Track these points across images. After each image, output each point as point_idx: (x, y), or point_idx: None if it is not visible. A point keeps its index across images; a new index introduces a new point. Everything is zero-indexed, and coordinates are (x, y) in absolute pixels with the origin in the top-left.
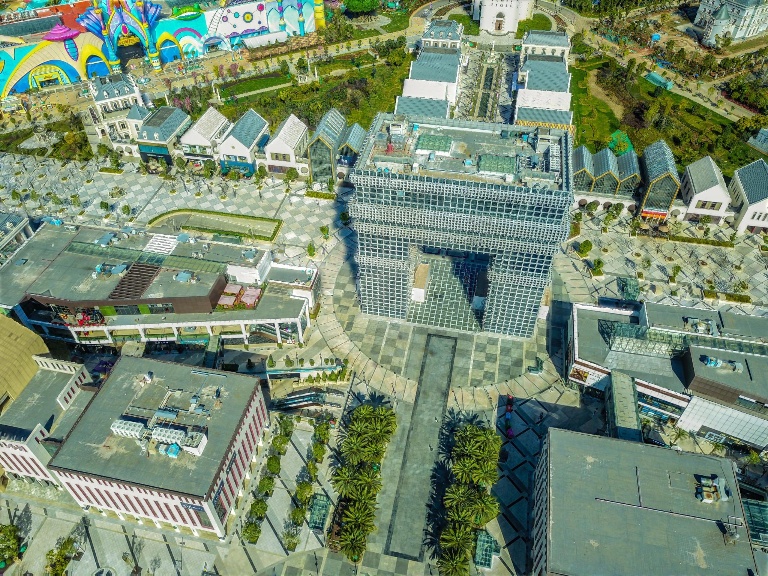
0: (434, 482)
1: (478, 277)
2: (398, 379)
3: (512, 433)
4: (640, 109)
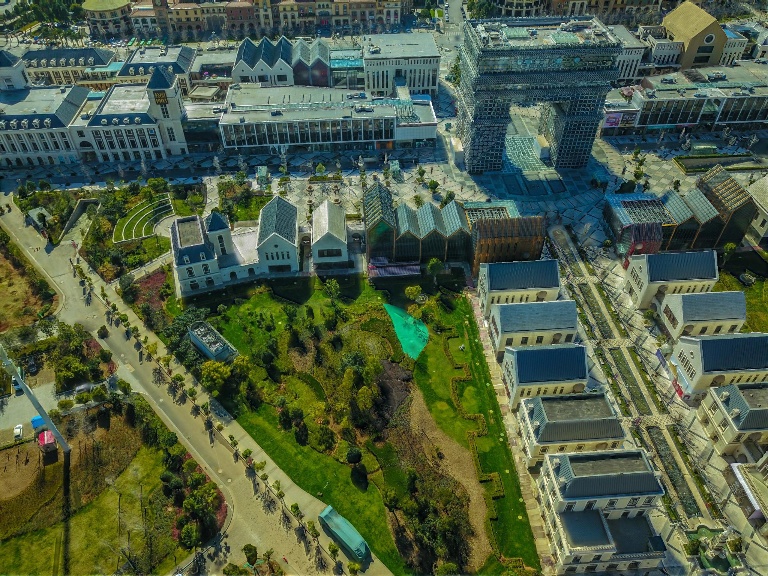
0: None
1: None
2: (521, 113)
3: (452, 101)
4: (384, 417)
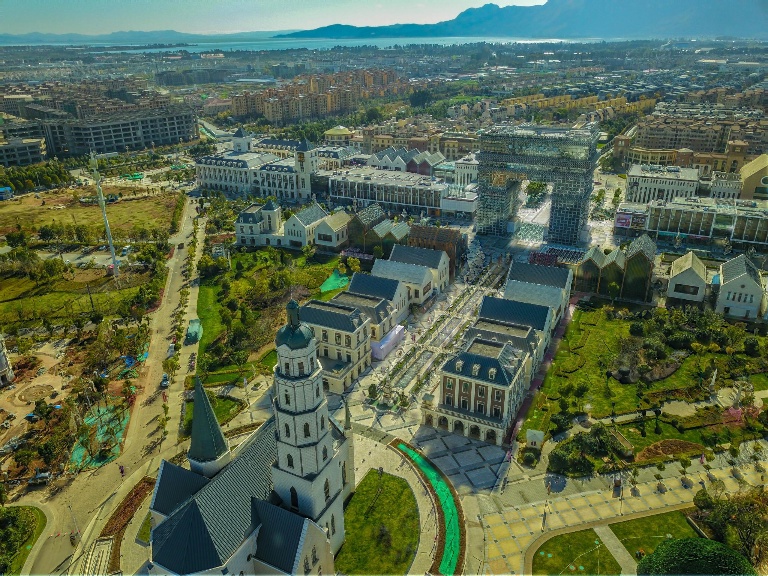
0: (549, 200)
1: (516, 221)
2: None
3: None
4: (272, 303)
